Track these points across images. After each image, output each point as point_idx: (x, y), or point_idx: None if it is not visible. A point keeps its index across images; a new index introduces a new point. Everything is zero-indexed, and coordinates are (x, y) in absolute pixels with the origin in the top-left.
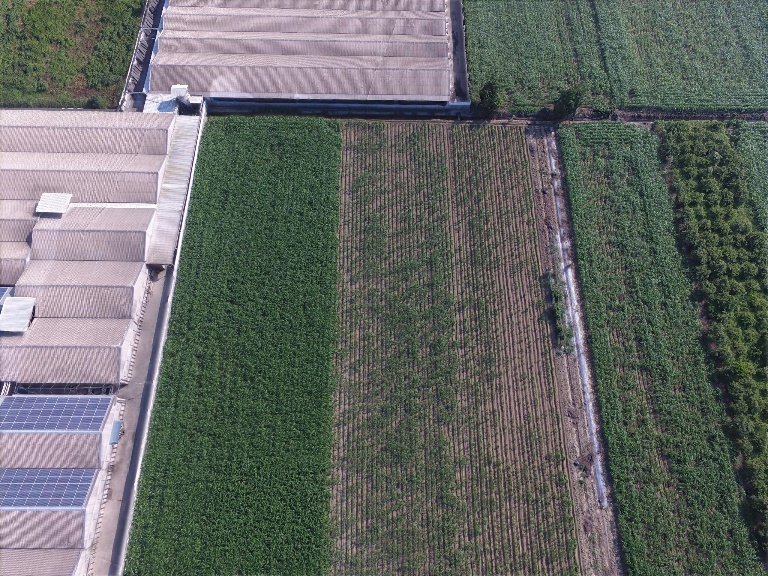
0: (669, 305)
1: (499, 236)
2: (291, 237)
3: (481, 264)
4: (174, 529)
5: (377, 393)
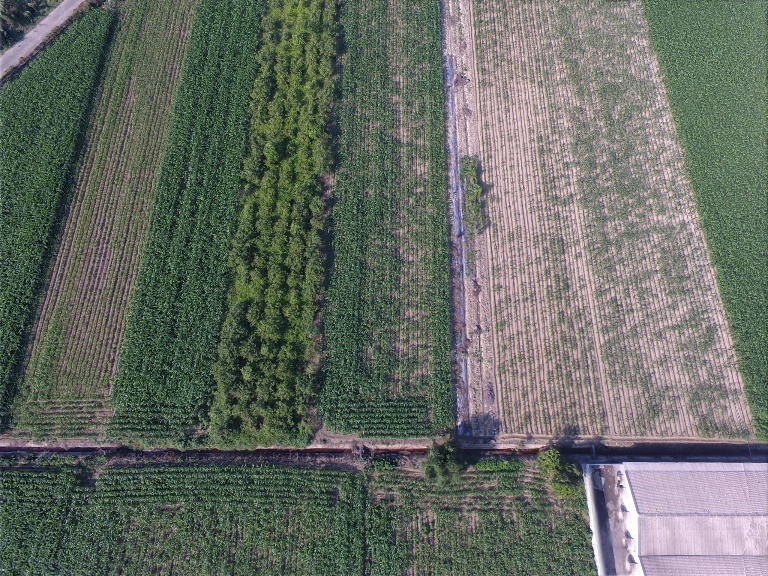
0: (361, 193)
1: (533, 271)
2: (767, 265)
3: (552, 240)
4: (766, 49)
5: (639, 128)
